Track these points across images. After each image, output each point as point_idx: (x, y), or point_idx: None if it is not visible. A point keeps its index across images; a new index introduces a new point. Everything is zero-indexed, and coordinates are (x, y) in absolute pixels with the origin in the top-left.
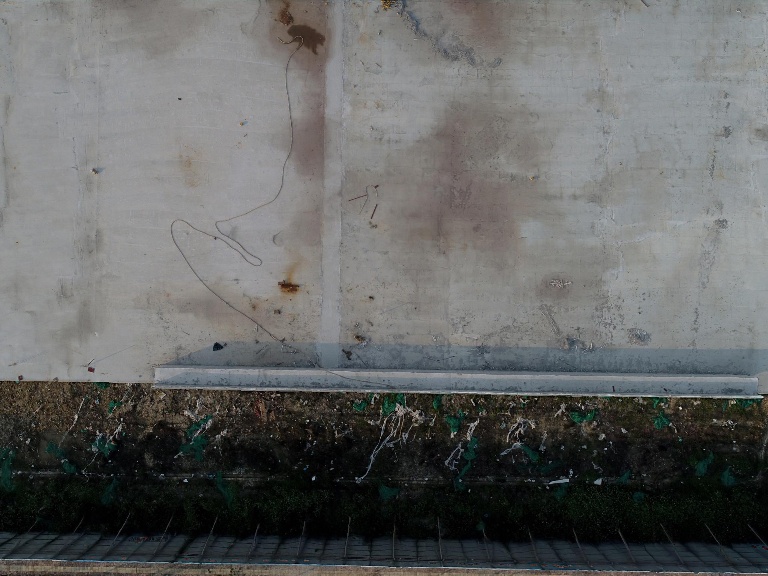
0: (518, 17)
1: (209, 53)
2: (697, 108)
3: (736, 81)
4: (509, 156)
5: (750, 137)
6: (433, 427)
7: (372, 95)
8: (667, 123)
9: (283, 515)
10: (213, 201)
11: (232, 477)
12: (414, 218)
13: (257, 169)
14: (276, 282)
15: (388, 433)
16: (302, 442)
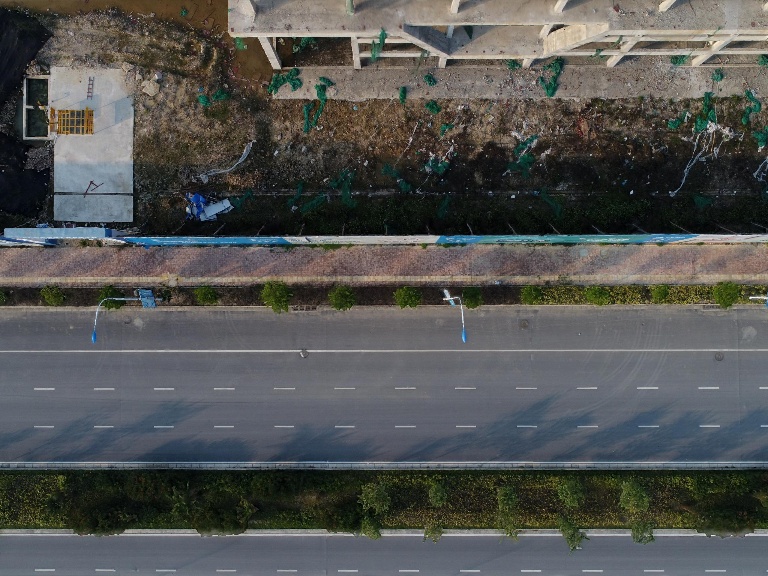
0: None
1: None
2: None
3: None
4: None
5: None
6: (742, 142)
7: None
8: None
9: (613, 219)
10: None
11: (555, 193)
12: None
13: None
14: None
15: (701, 148)
16: (622, 157)
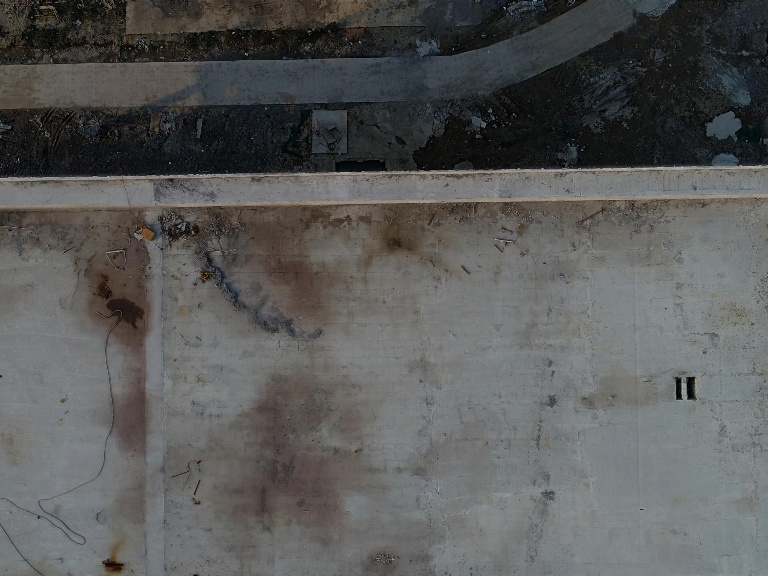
0: (338, 287)
1: (29, 329)
2: (521, 377)
3: (560, 349)
4: (332, 429)
5: (576, 406)
6: None
7: (192, 369)
8: (491, 393)
9: None
10: (35, 479)
11: None
12: (237, 494)
13: (79, 446)
14: (100, 561)
15: None
16: None
